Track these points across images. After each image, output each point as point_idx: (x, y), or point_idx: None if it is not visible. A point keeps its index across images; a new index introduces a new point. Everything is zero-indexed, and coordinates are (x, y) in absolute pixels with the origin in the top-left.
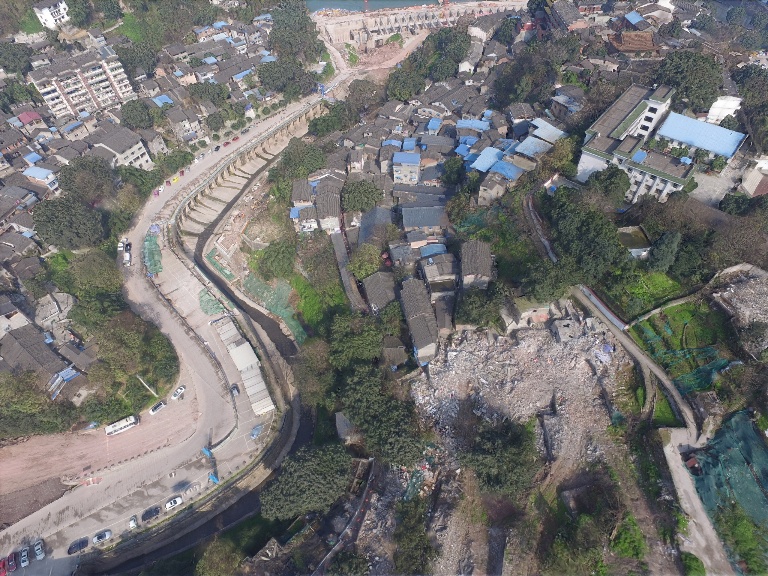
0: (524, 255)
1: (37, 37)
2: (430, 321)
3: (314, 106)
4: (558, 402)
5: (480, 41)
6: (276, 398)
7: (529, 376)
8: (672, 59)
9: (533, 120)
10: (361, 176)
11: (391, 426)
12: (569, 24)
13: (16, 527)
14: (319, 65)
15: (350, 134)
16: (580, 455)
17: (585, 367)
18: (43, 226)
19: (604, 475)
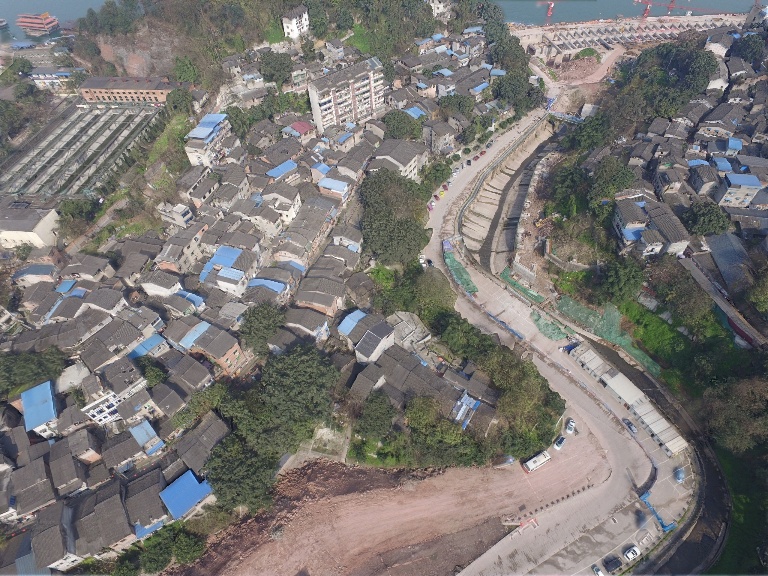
0: None
1: (278, 47)
2: None
3: (543, 121)
4: None
5: (721, 57)
6: None
7: None
8: None
9: None
10: (679, 197)
11: None
12: None
13: (471, 570)
14: (530, 79)
15: (639, 152)
16: None
17: None
18: (381, 241)
19: None
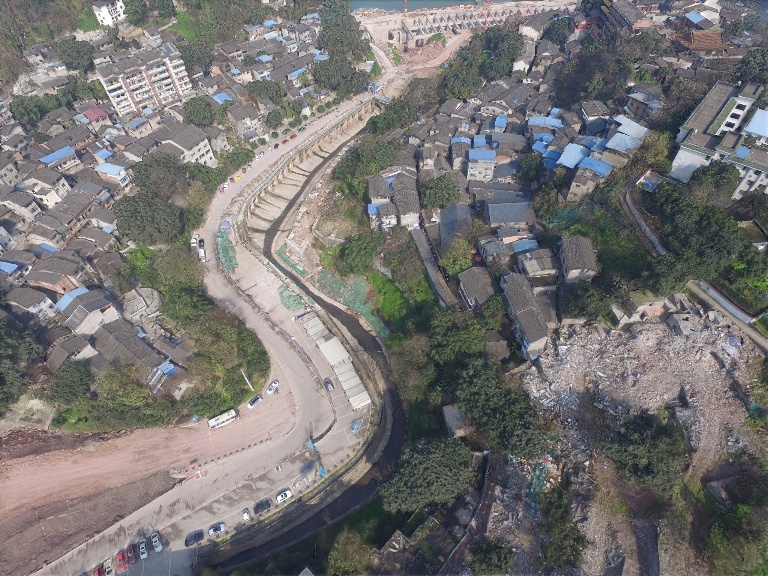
0: (628, 250)
1: (94, 35)
2: (538, 315)
3: (366, 104)
4: (688, 394)
5: (532, 40)
6: (370, 393)
7: (652, 369)
8: (755, 57)
9: (615, 117)
10: (433, 173)
11: (516, 418)
12: (634, 23)
13: (129, 519)
14: (366, 64)
15: (416, 131)
16: (720, 446)
17: (711, 360)
18: (126, 221)
19: (753, 466)
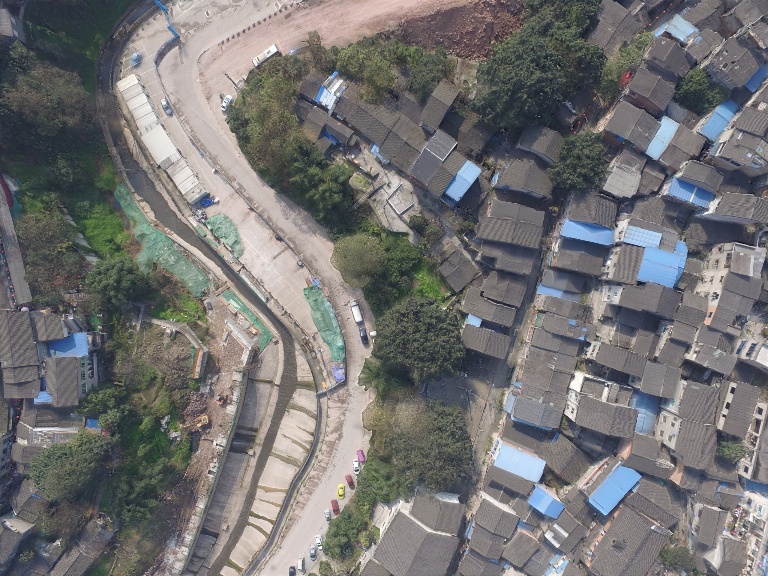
0: None
1: None
2: None
3: None
4: None
5: None
6: None
7: None
8: None
9: None
10: None
11: None
12: None
13: None
14: None
15: (3, 541)
16: None
17: None
18: None
19: None
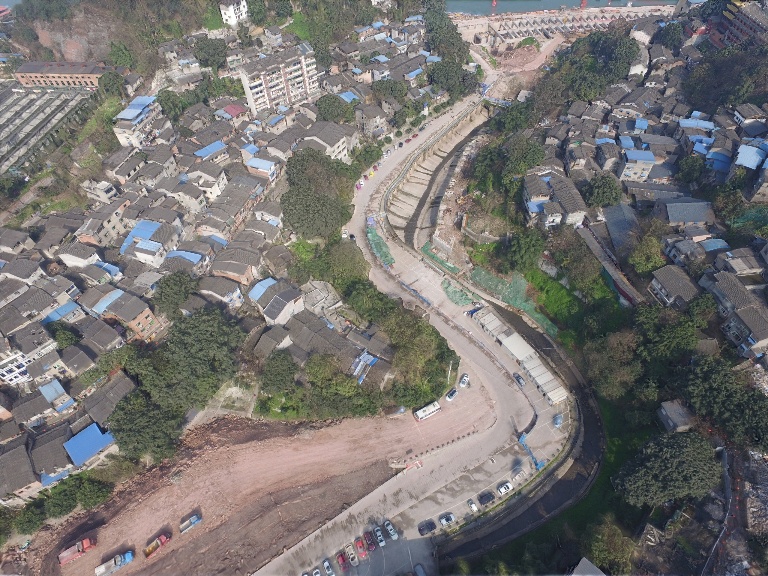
0: None
1: (217, 33)
2: (760, 313)
3: (477, 106)
4: None
5: (644, 45)
6: None
7: None
8: None
9: None
10: (584, 173)
11: None
12: None
13: (357, 507)
14: (469, 66)
15: (554, 132)
16: None
17: None
18: (297, 215)
19: None
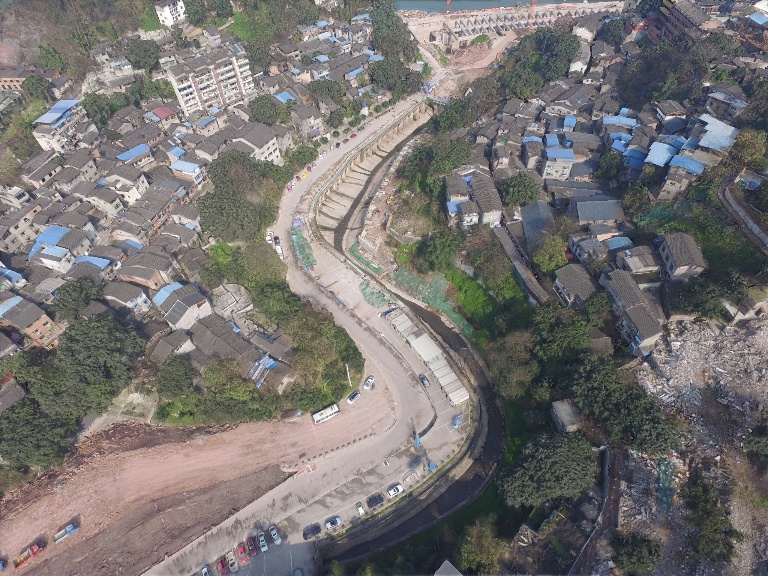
0: (735, 247)
1: (154, 35)
2: (649, 311)
3: (421, 105)
4: None
5: (586, 41)
6: None
7: None
8: None
9: None
10: (508, 172)
11: (642, 413)
12: (701, 23)
13: (244, 512)
14: (417, 65)
15: (484, 131)
16: None
17: None
18: (212, 218)
19: None
